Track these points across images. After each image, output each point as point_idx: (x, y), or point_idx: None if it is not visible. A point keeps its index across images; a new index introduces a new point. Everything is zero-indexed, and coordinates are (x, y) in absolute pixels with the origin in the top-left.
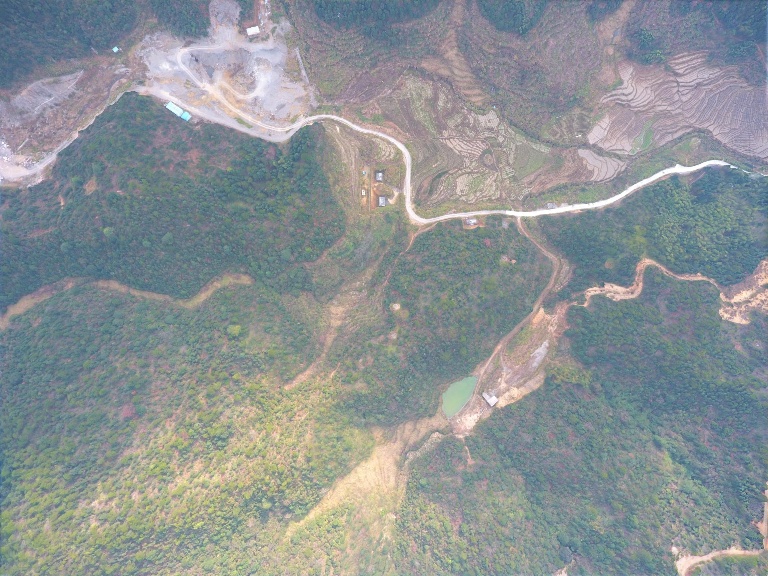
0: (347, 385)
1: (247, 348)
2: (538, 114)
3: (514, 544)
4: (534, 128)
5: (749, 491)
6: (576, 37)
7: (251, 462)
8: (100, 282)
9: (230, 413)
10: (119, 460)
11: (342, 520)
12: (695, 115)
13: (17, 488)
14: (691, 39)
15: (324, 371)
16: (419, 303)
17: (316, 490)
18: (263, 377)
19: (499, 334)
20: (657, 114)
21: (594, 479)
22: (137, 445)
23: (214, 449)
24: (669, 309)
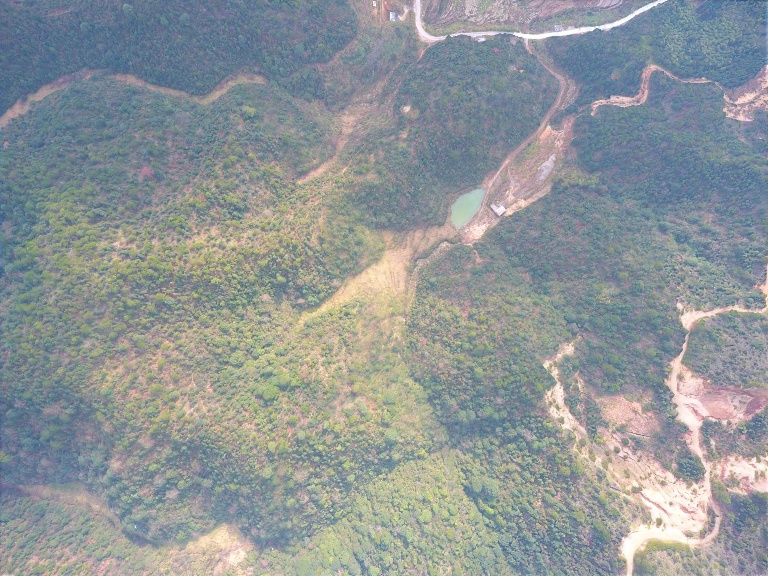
0: (359, 176)
1: (262, 132)
2: None
3: (522, 320)
4: None
5: (752, 257)
6: None
7: (266, 235)
8: (118, 76)
9: (245, 189)
10: (139, 215)
11: (354, 311)
12: None
13: (42, 217)
14: None
15: (336, 167)
16: (429, 99)
17: (328, 281)
18: (277, 164)
19: (507, 142)
20: None
21: (601, 255)
22: (156, 204)
23: (230, 219)
24: (674, 108)
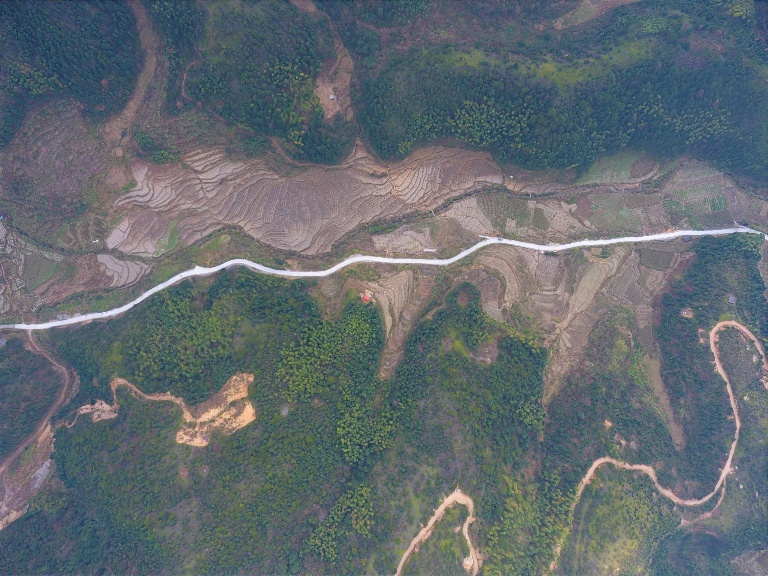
0: None
1: None
2: (47, 222)
3: None
4: (43, 237)
5: None
6: (72, 143)
7: None
8: None
9: None
10: None
11: None
12: (223, 211)
13: None
14: (199, 137)
15: None
16: None
17: None
18: None
19: None
20: (182, 213)
21: None
22: None
23: None
24: None
